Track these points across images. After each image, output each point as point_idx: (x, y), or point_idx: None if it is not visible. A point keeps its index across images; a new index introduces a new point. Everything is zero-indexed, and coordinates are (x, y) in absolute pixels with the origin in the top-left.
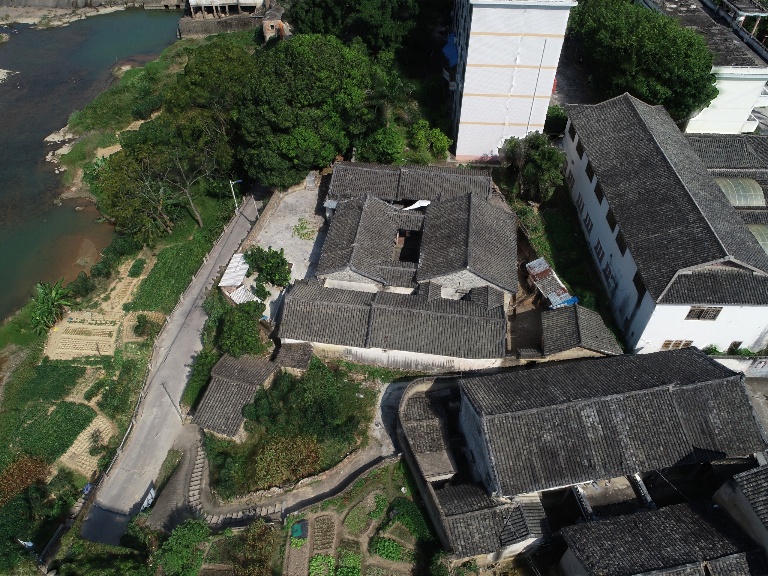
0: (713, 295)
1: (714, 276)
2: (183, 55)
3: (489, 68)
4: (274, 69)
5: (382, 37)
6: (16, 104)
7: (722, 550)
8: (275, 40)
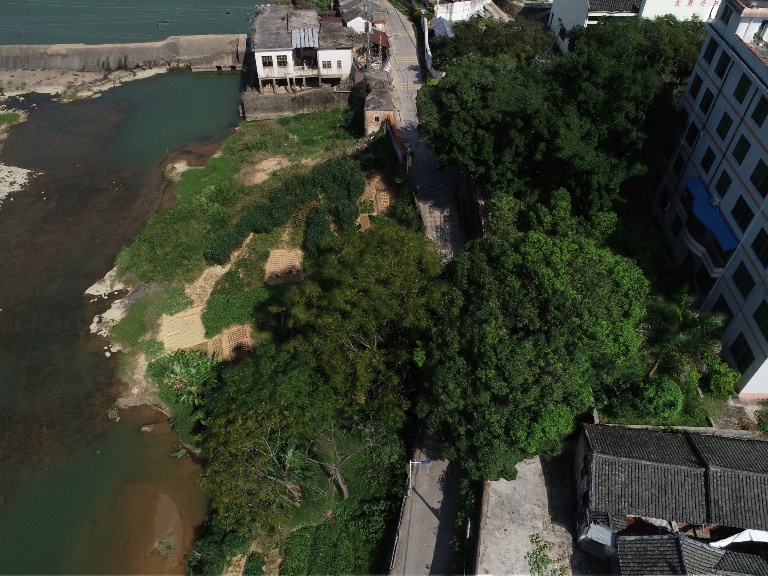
0: None
1: None
2: (255, 149)
3: None
4: (500, 303)
5: (596, 188)
6: (43, 227)
7: None
8: (385, 141)
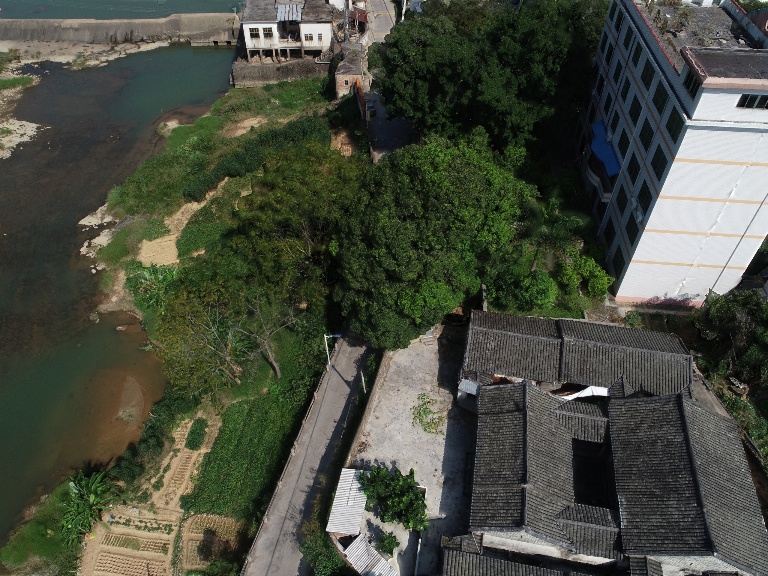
0: None
1: None
2: (239, 110)
3: (689, 201)
4: (394, 197)
5: (510, 127)
6: (46, 171)
7: None
8: (351, 101)
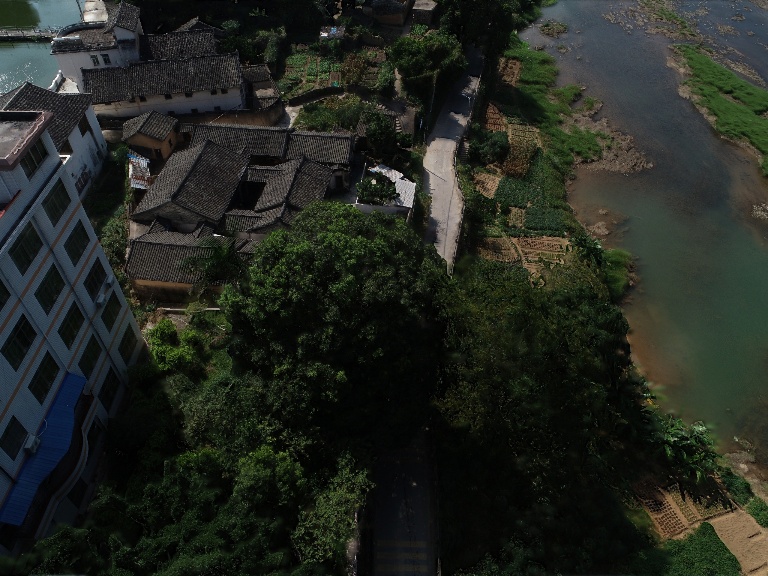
0: None
1: None
2: None
3: None
4: None
5: None
6: None
7: (155, 37)
8: None
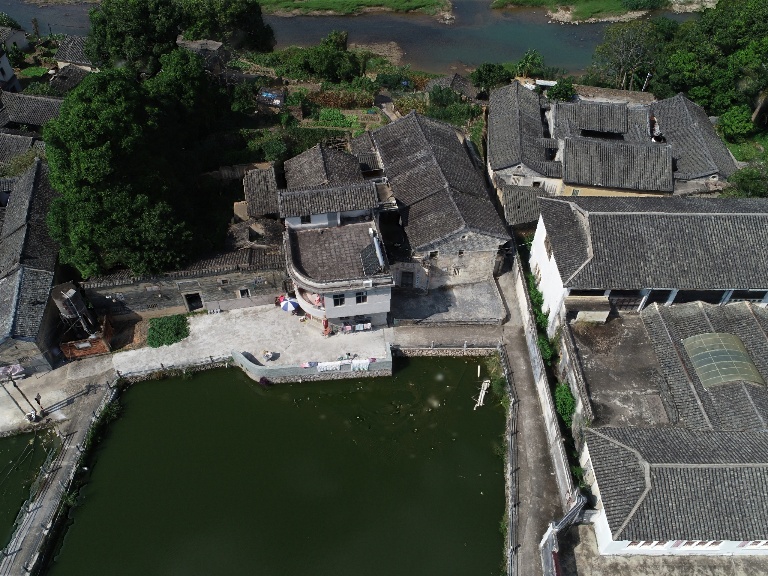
0: (554, 227)
1: (575, 224)
2: None
3: None
4: None
5: None
6: None
7: None
8: None
